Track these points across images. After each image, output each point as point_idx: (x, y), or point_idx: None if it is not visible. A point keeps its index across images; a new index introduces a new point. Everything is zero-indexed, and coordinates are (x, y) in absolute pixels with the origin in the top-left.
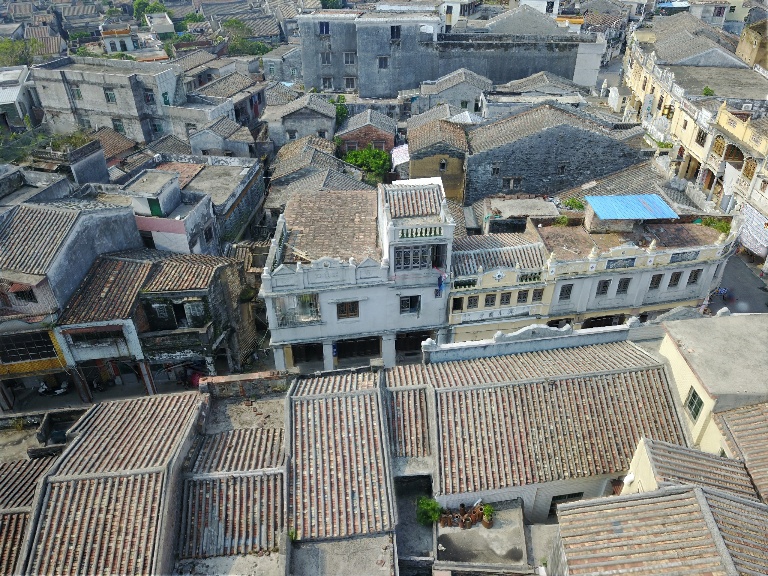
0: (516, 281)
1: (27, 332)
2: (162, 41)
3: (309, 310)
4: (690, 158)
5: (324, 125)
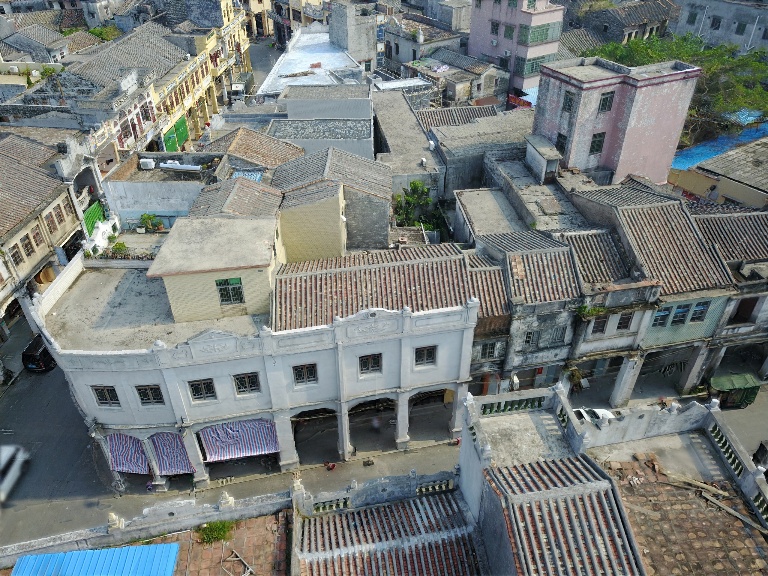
0: None
1: None
2: None
3: None
4: None
5: None
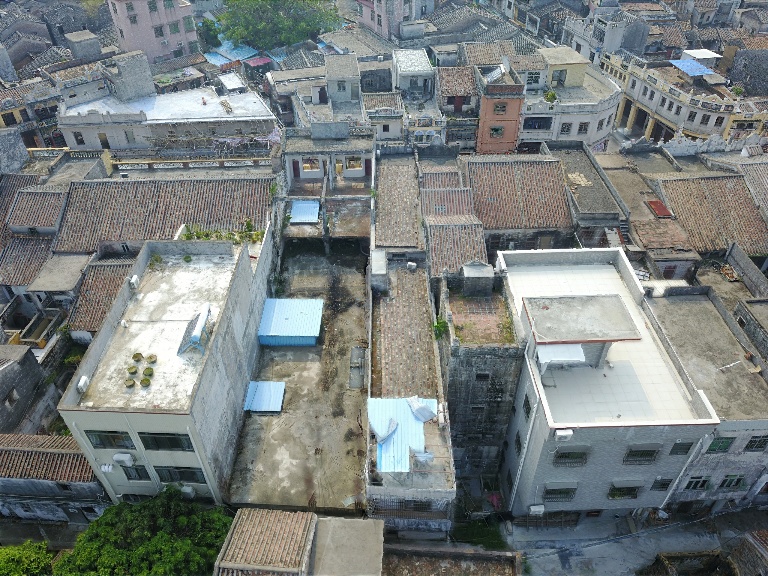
0: (620, 66)
1: (523, 10)
2: None
3: (570, 41)
4: None
5: (756, 25)
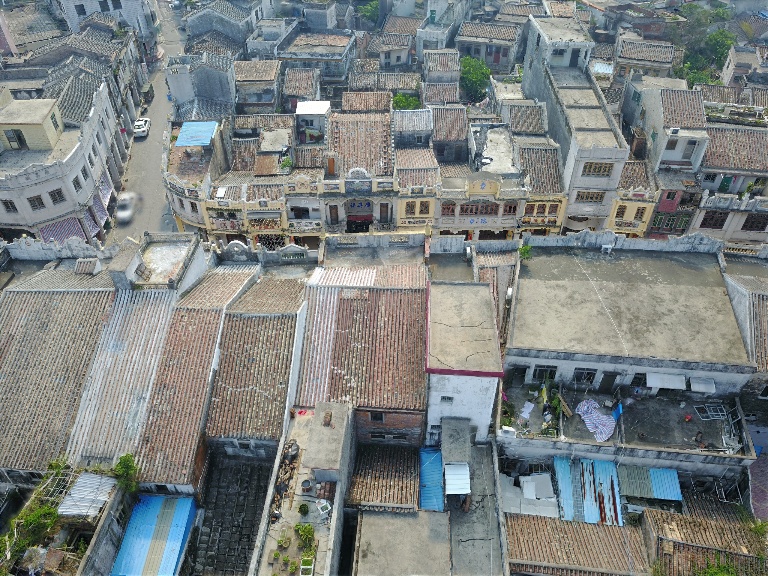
0: None
1: None
2: (714, 8)
3: None
4: None
5: None
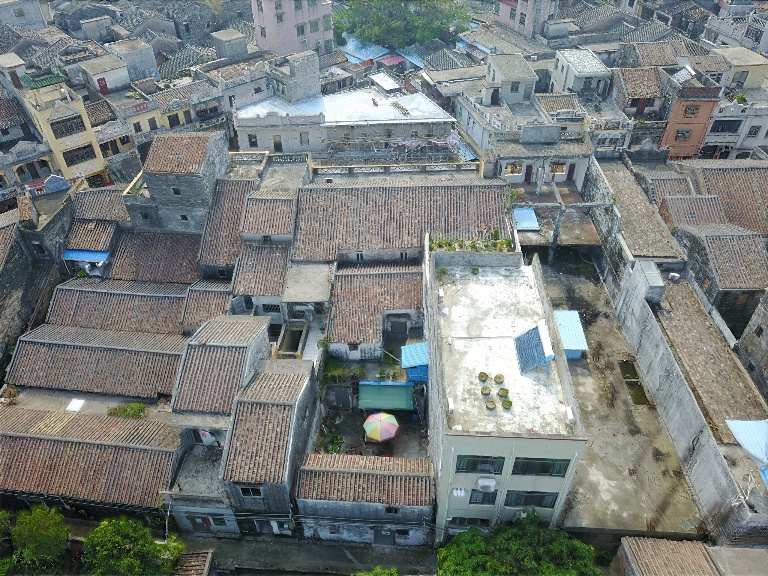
0: None
1: (650, 8)
2: None
3: (713, 40)
4: None
5: None
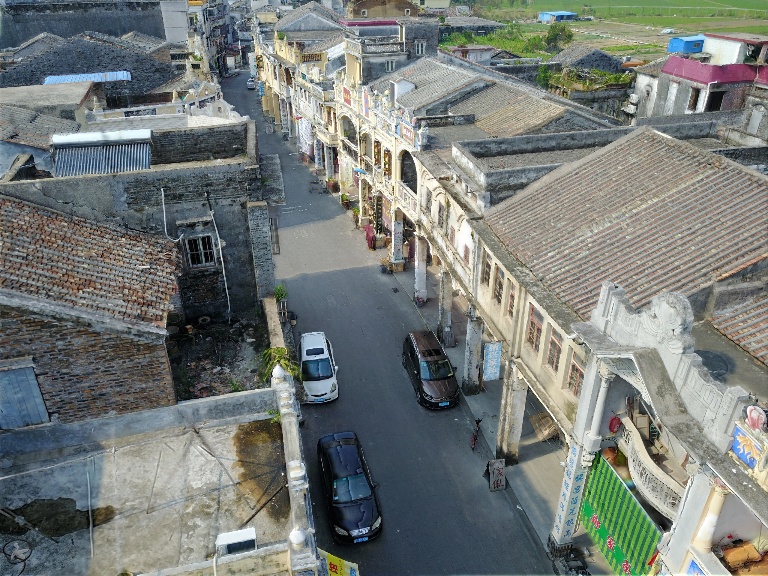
0: None
1: None
2: None
3: None
4: (278, 97)
5: None
